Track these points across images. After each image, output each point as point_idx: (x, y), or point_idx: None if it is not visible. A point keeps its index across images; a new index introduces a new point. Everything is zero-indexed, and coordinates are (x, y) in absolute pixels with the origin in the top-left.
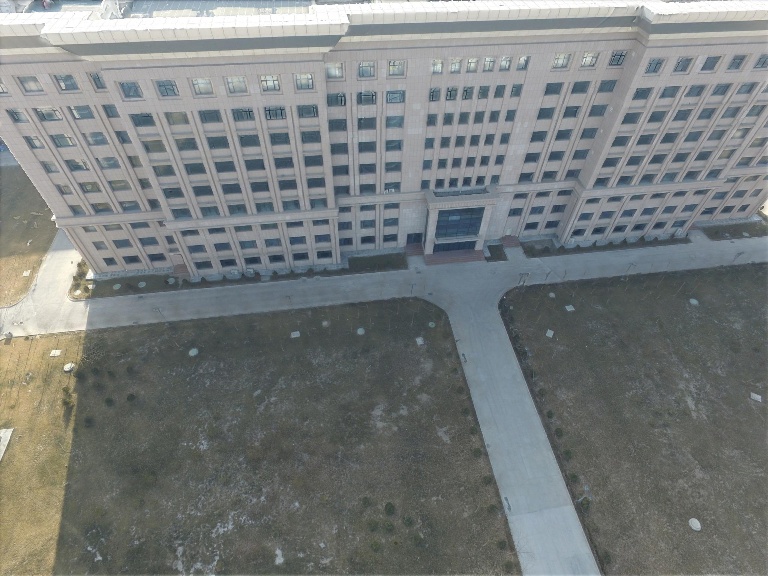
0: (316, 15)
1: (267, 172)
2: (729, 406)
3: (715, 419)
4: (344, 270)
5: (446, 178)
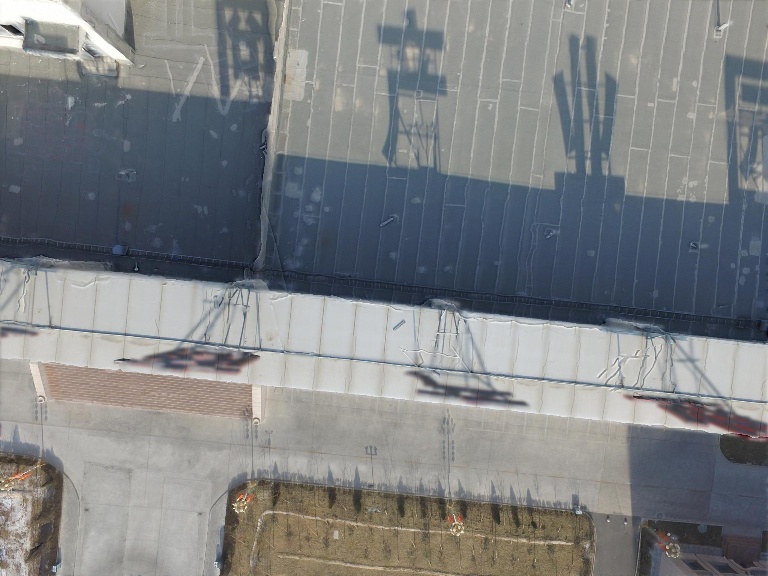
0: None
1: None
2: None
3: None
4: None
5: None
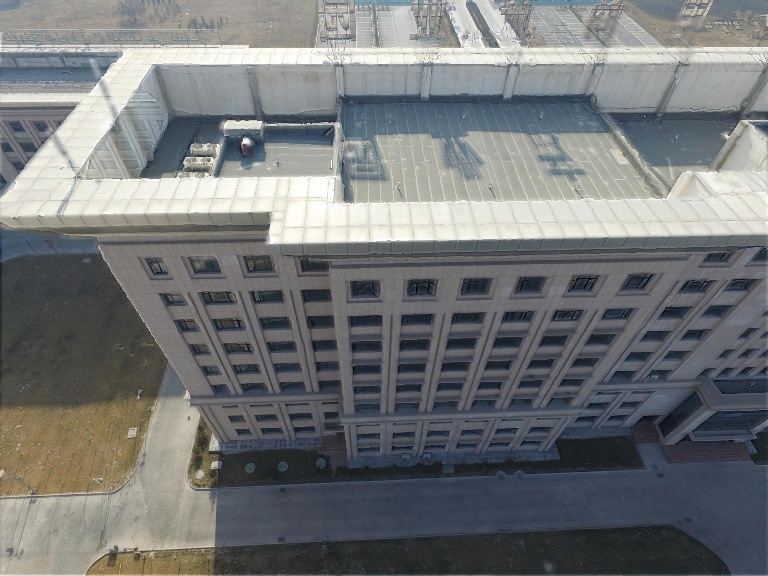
0: (727, 205)
1: (512, 373)
2: None
3: None
4: (557, 466)
5: (740, 367)
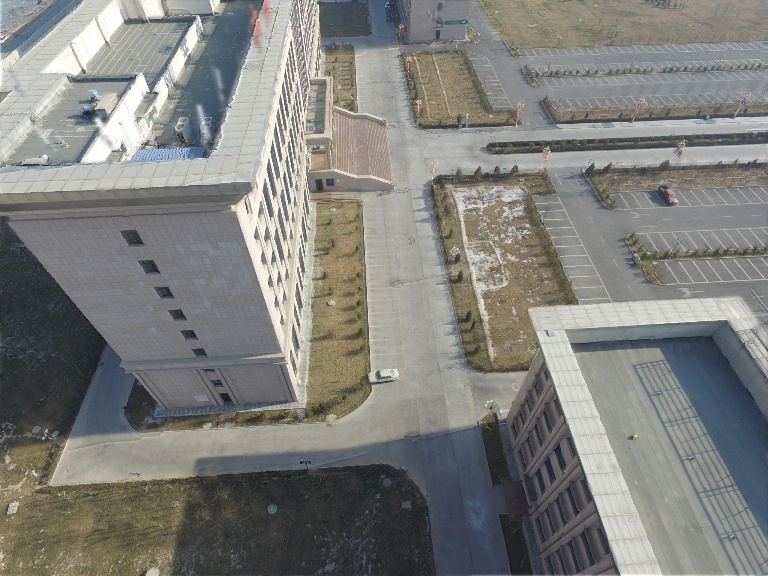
0: None
1: None
2: (5, 265)
3: (5, 253)
4: None
5: None
